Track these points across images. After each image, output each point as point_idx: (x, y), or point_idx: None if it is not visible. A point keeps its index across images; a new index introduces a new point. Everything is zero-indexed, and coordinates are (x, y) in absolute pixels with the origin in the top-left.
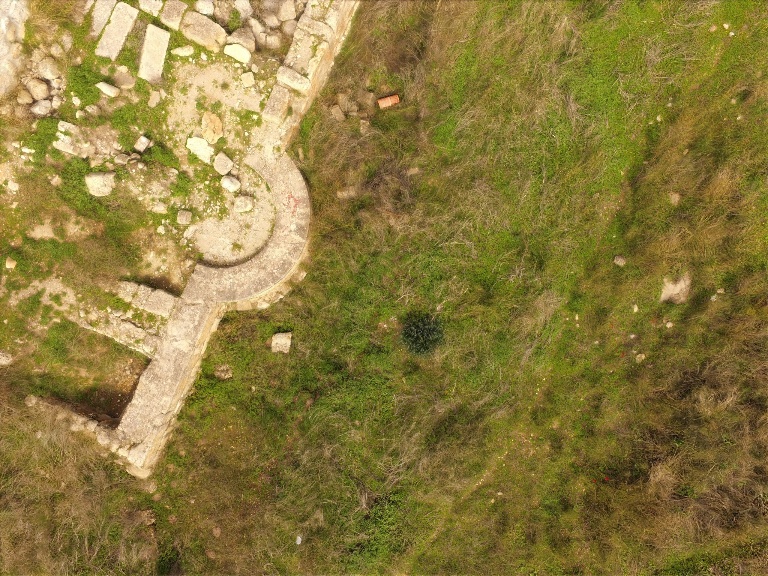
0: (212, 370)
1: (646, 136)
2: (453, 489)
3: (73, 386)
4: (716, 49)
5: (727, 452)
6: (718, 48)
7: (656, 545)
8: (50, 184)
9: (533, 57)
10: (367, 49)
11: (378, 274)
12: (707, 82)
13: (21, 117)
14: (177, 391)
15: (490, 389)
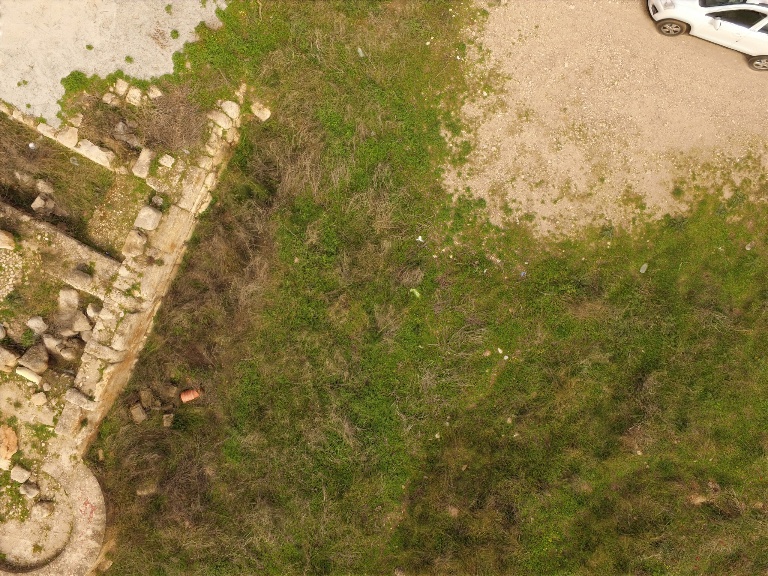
0: None
1: (427, 451)
2: None
3: None
4: (492, 370)
5: None
6: (494, 369)
7: None
8: None
9: (314, 378)
10: None
11: (175, 573)
12: (484, 401)
13: None
14: None
15: None
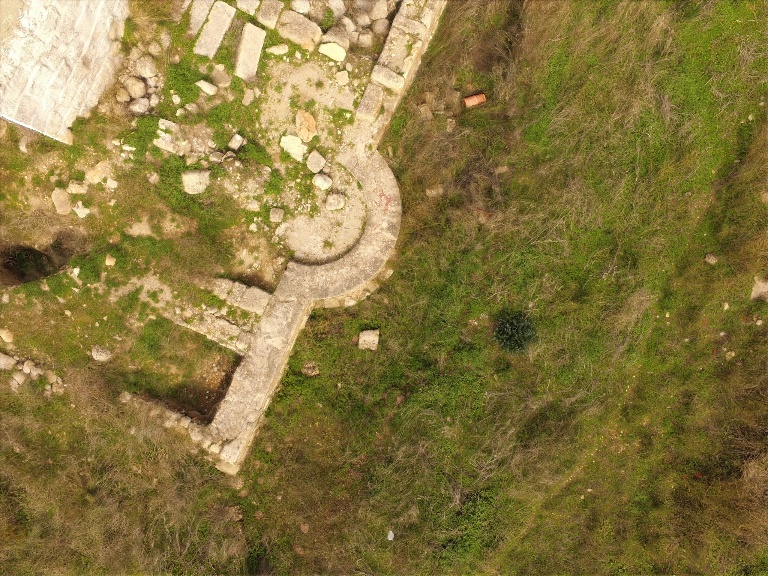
0: (299, 367)
1: (737, 135)
2: (545, 485)
3: (164, 383)
4: None
5: None
6: None
7: (748, 541)
8: (148, 182)
9: (626, 56)
10: (457, 48)
11: (468, 272)
12: None
13: (121, 115)
14: (269, 388)
15: (581, 386)
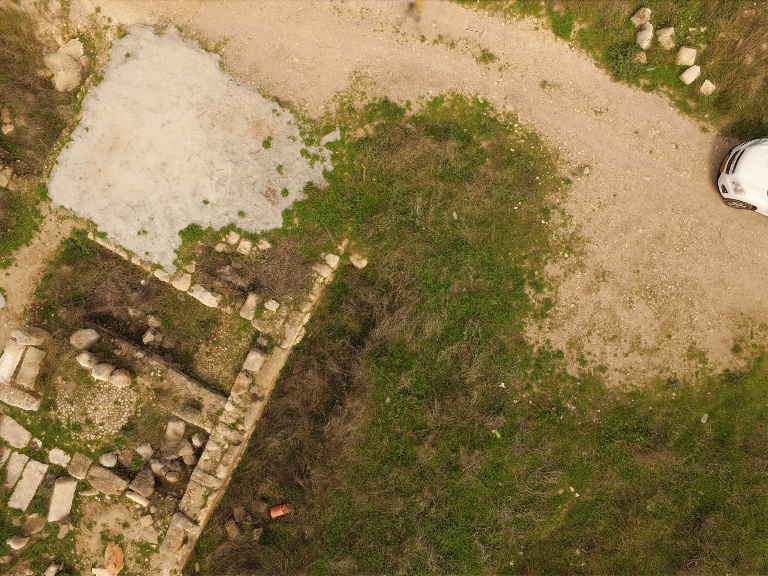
0: None
1: (501, 575)
2: None
3: None
4: (564, 506)
5: None
6: (566, 505)
7: None
8: None
9: None
10: None
11: None
12: (555, 533)
13: None
14: None
15: None
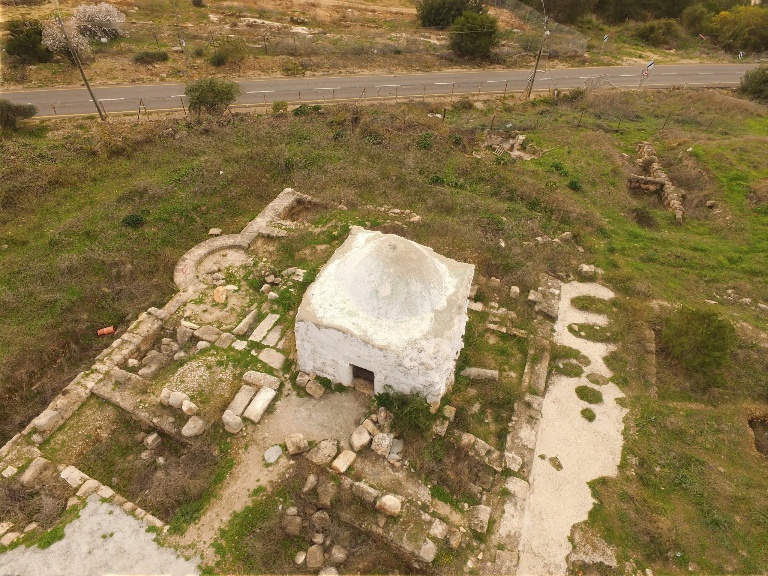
0: None
1: None
2: None
3: None
4: None
5: (4, 186)
6: None
7: None
8: None
9: None
10: None
11: None
12: None
13: None
14: None
15: None
